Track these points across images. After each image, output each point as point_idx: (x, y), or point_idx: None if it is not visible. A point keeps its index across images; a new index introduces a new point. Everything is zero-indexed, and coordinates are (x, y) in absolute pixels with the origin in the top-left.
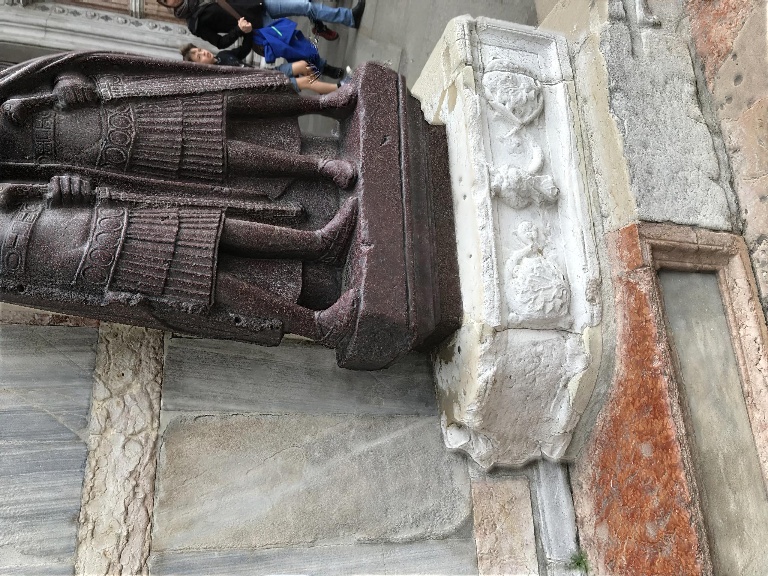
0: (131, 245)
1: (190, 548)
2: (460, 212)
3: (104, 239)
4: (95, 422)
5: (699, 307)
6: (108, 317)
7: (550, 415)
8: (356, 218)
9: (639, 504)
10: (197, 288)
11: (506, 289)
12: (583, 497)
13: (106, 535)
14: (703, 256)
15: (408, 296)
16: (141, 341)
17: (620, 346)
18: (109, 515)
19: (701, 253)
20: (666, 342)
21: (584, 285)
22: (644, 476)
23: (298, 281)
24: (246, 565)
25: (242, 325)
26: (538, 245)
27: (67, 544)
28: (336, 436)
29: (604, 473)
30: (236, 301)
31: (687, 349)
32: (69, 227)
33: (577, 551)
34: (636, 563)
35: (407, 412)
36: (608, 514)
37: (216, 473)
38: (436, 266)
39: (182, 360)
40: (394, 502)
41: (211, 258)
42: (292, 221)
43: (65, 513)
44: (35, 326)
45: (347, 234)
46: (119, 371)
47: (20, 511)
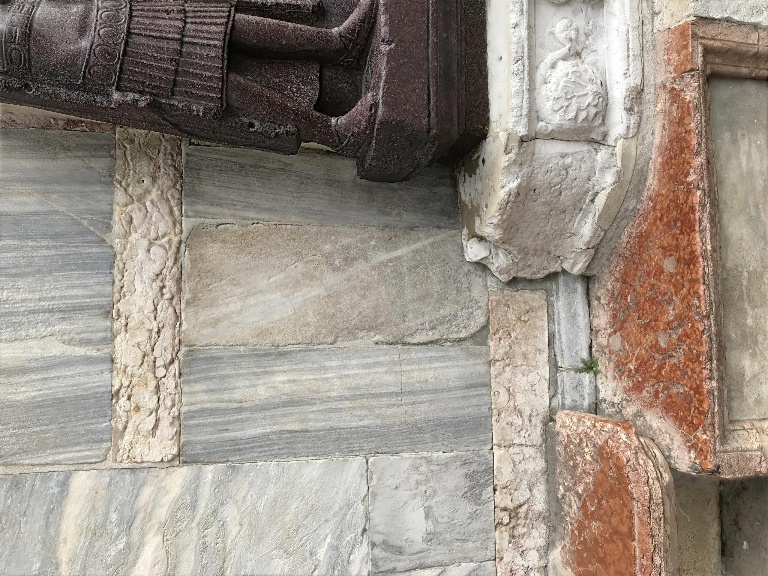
0: (136, 41)
1: (217, 345)
2: (493, 8)
3: (107, 34)
4: (120, 227)
5: (748, 118)
6: (120, 120)
7: (574, 231)
8: (376, 13)
9: (654, 318)
10: (207, 89)
11: (537, 95)
12: (600, 312)
13: (139, 331)
14: (762, 59)
15: (430, 101)
16: (159, 148)
17: (655, 159)
18: (140, 313)
19: (760, 56)
20: (704, 154)
21: (623, 92)
22: (662, 291)
23: (315, 85)
24: (270, 362)
25: (256, 130)
26: (577, 46)
27: (104, 337)
28: (356, 247)
29: (623, 289)
30: (249, 104)
31: (727, 163)
32: (69, 20)
33: (588, 361)
34: (643, 372)
35: (428, 225)
36: (622, 327)
37: (239, 278)
38: (463, 70)
39: (201, 168)
40: (412, 311)
41: (220, 57)
42: (308, 18)
43: (99, 310)
44: (52, 131)
45: (367, 32)
46: (139, 178)
47: (58, 307)
